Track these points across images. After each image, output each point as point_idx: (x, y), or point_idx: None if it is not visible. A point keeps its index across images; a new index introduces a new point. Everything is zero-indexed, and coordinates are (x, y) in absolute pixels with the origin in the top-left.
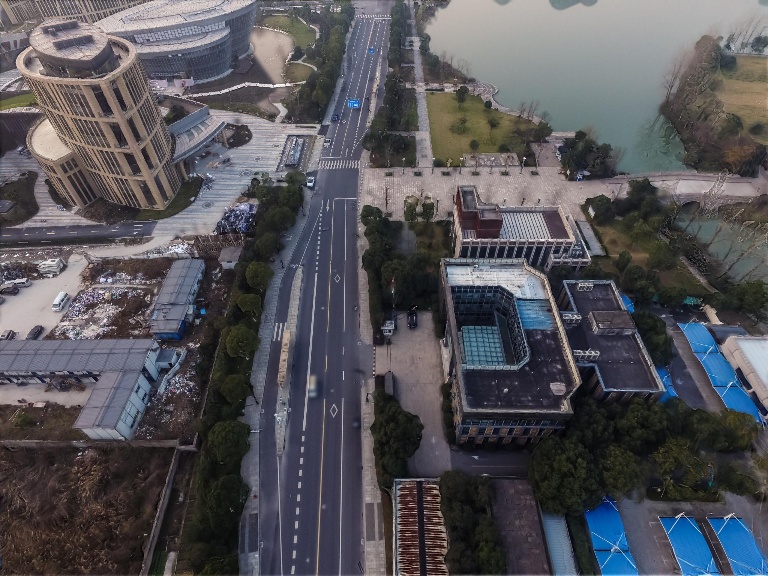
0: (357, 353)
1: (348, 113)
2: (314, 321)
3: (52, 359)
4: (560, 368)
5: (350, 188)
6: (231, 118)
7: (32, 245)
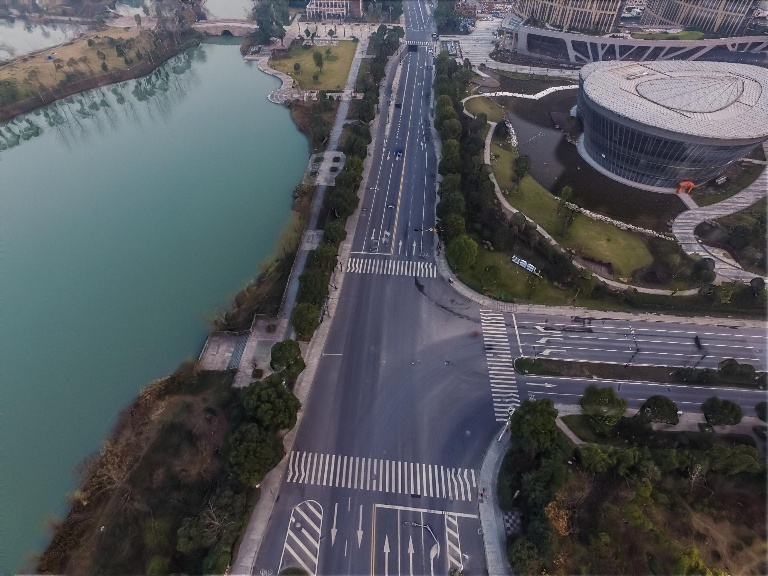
0: (403, 2)
1: (419, 72)
2: (419, 6)
3: None
4: None
5: None
6: (519, 68)
7: None
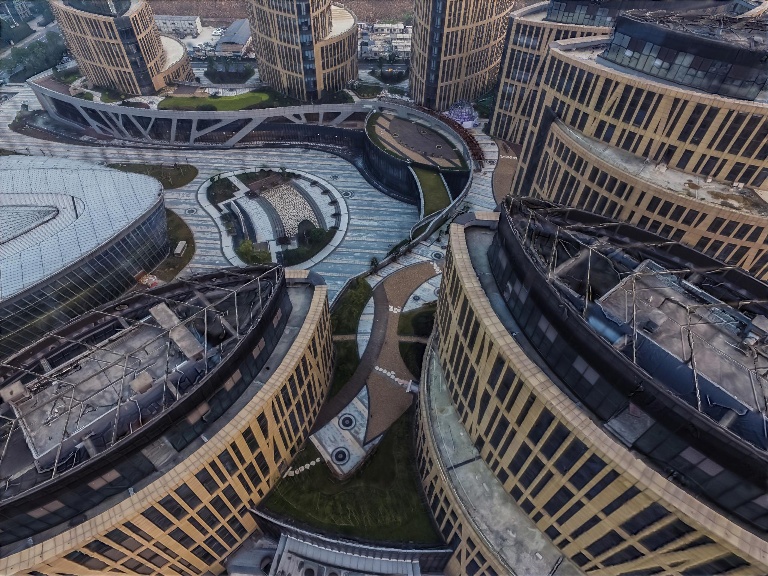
0: None
1: None
2: None
3: None
4: None
5: None
6: (19, 141)
7: (199, 60)
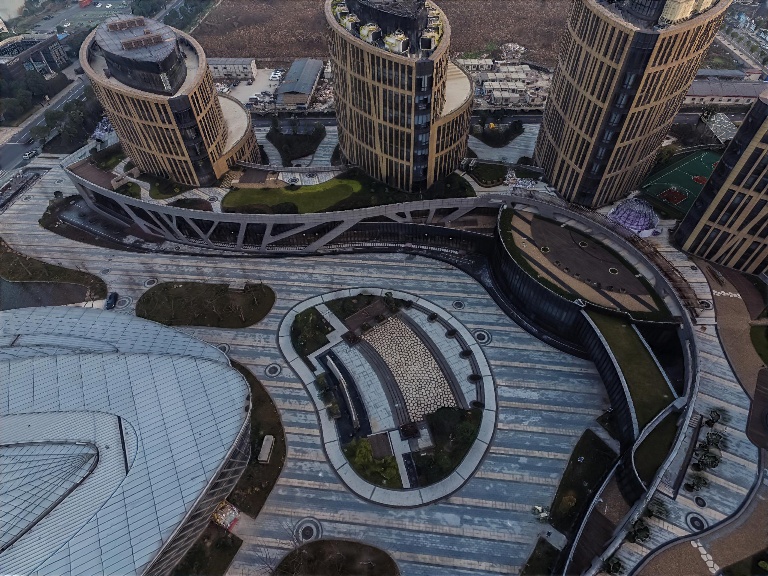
0: (85, 79)
1: None
2: None
3: (211, 59)
4: (9, 44)
5: (2, 151)
6: (51, 245)
7: None
